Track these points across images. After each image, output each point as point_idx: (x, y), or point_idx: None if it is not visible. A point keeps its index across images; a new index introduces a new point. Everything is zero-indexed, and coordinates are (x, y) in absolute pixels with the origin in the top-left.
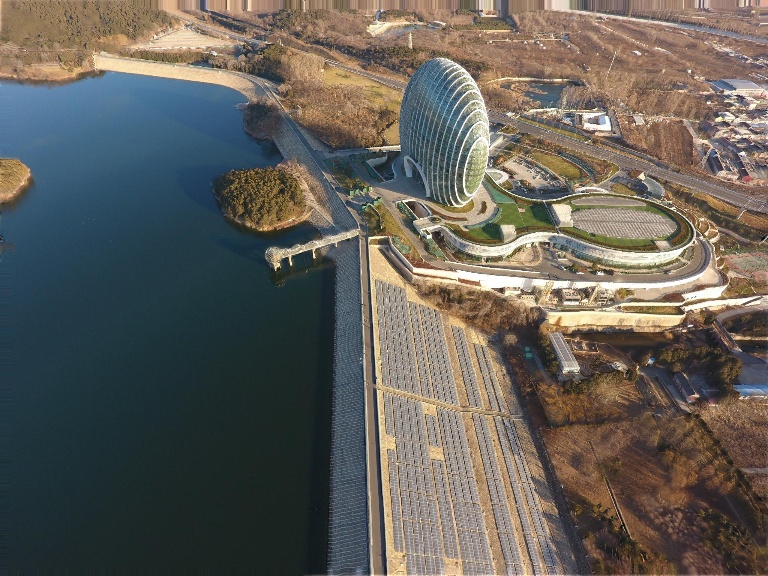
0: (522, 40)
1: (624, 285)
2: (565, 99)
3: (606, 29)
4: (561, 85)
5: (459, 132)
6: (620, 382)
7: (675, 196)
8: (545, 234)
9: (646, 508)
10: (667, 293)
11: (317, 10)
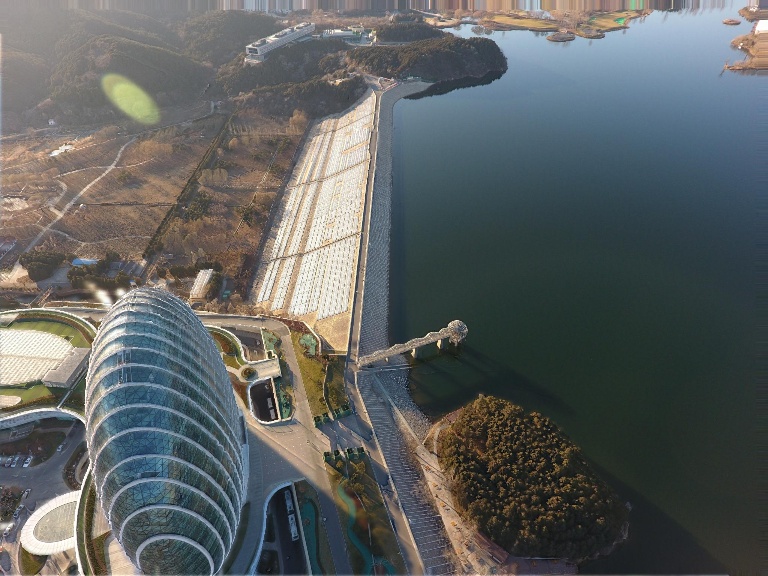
0: None
1: None
2: None
3: None
4: None
5: None
6: None
7: None
8: None
9: None
10: None
11: None
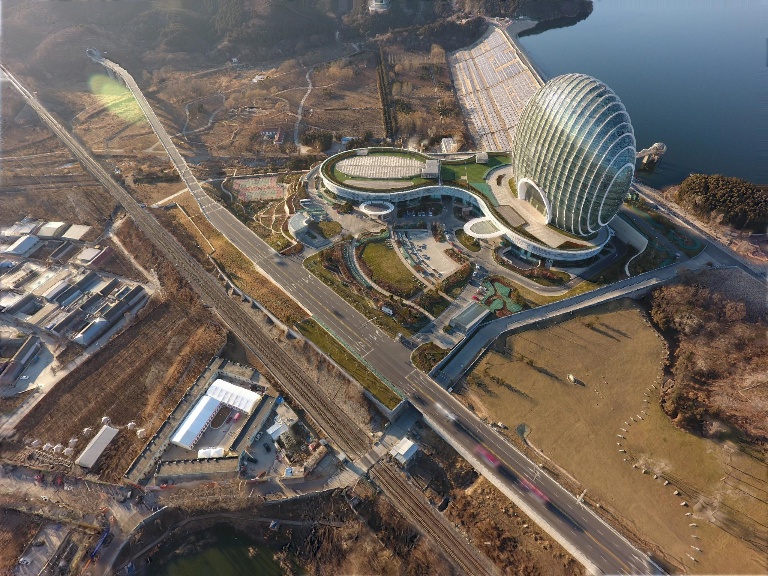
0: None
1: None
2: (281, 418)
3: None
4: None
5: None
6: None
7: None
8: None
9: None
10: None
11: None
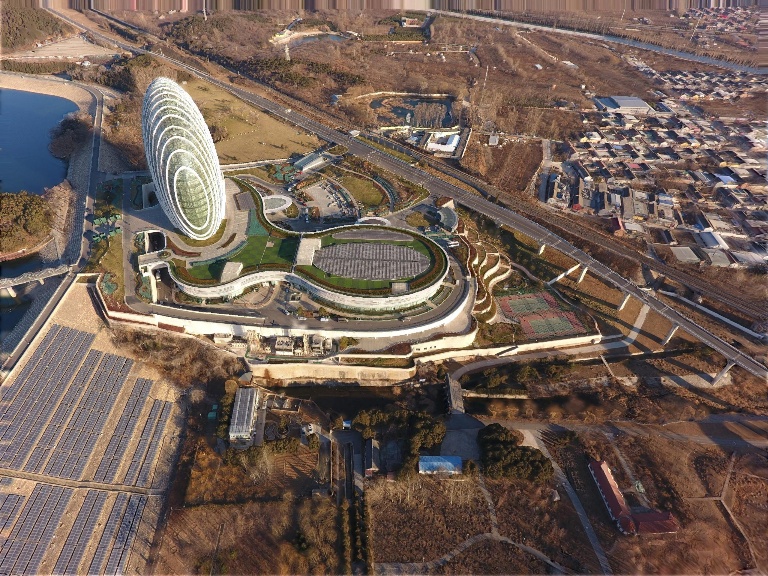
0: (426, 52)
1: (345, 334)
2: (408, 117)
3: (522, 41)
4: (441, 100)
5: (160, 161)
6: (297, 450)
7: (479, 227)
8: (277, 273)
9: None
10: (397, 343)
11: (220, 19)
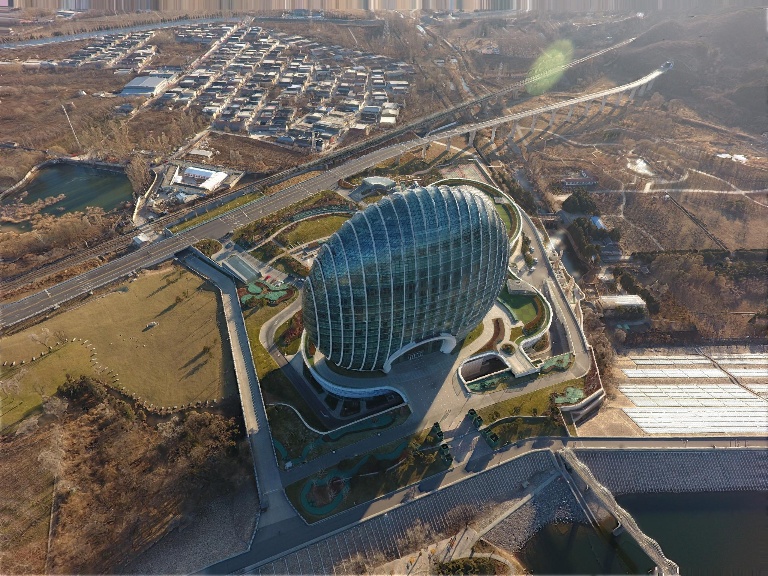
0: None
1: None
2: (165, 178)
3: None
4: (35, 178)
5: None
6: None
7: None
8: None
9: (734, 298)
10: None
11: None
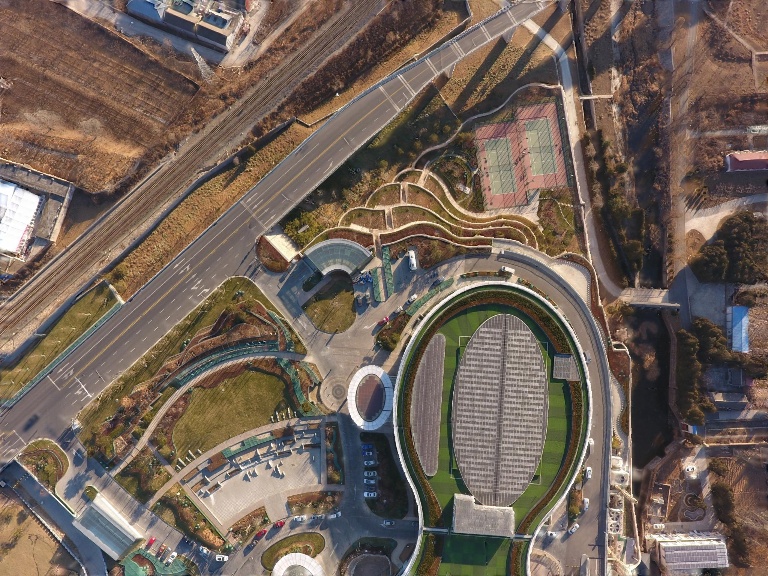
0: None
1: None
2: None
3: None
4: None
5: None
6: None
7: (332, 200)
8: None
9: None
10: None
11: None
